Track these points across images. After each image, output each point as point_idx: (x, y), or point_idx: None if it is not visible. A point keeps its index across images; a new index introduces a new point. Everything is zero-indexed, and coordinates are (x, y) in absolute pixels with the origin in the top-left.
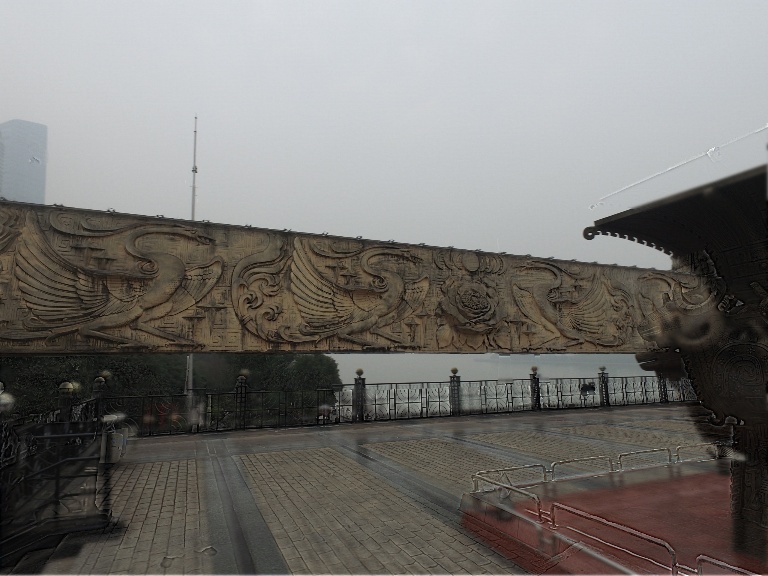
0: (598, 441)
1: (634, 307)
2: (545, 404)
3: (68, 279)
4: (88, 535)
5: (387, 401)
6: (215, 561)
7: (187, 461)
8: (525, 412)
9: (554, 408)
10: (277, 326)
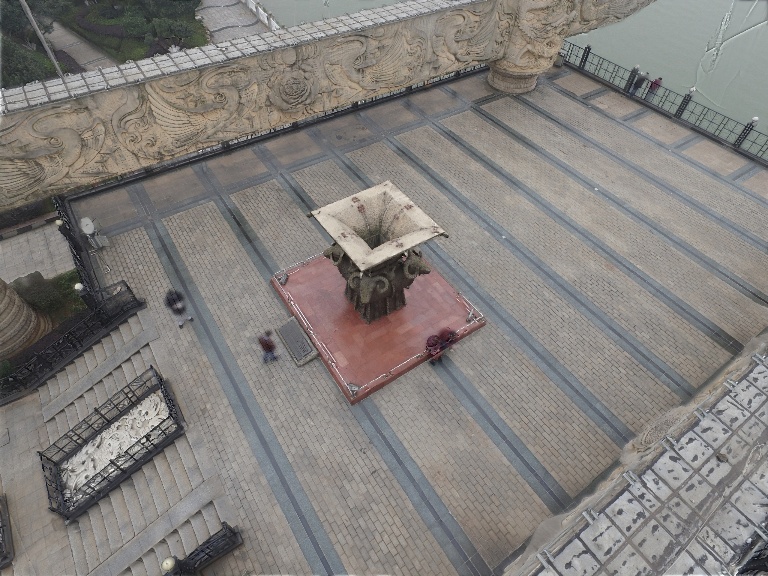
0: (361, 185)
1: (426, 49)
2: (362, 101)
3: (9, 165)
4: (145, 312)
5: None
6: (195, 324)
7: (140, 230)
8: (346, 111)
9: (369, 101)
10: (157, 148)
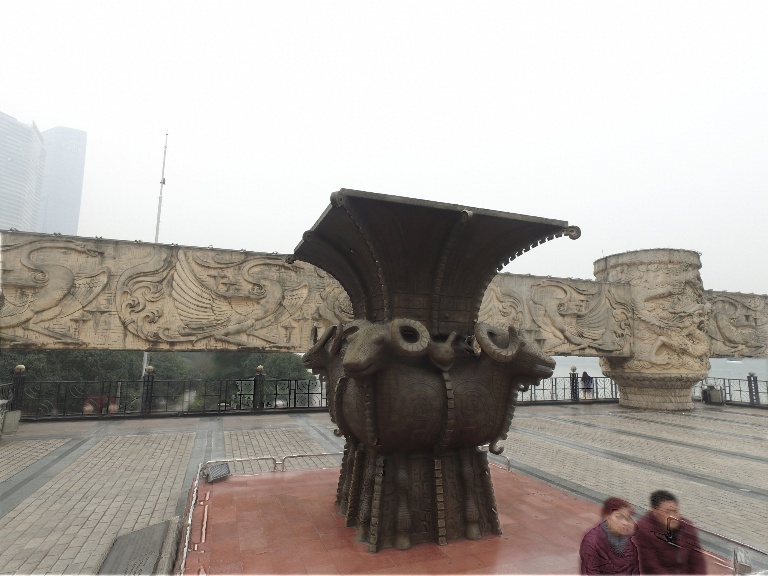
0: None
1: (523, 313)
2: None
3: None
4: None
5: (288, 391)
6: None
7: (63, 440)
8: None
9: None
10: (157, 328)
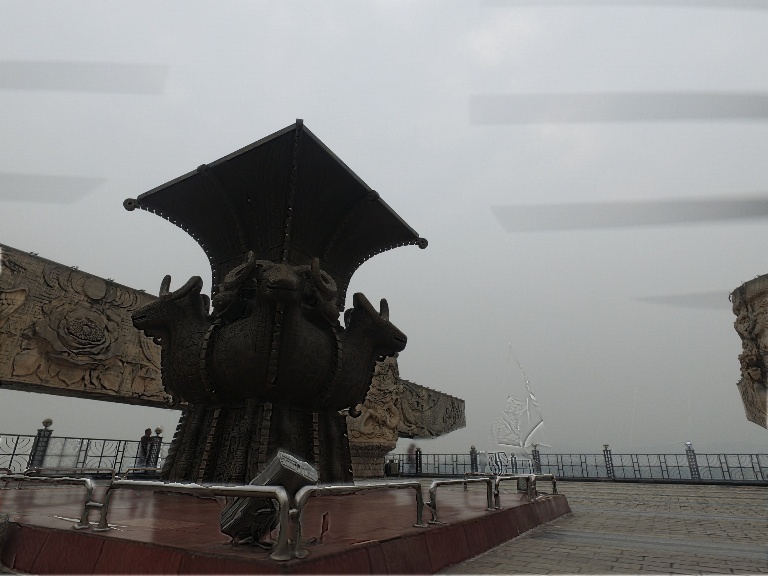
0: None
1: None
2: None
3: None
4: None
5: None
6: None
7: None
8: (134, 474)
9: None
10: None
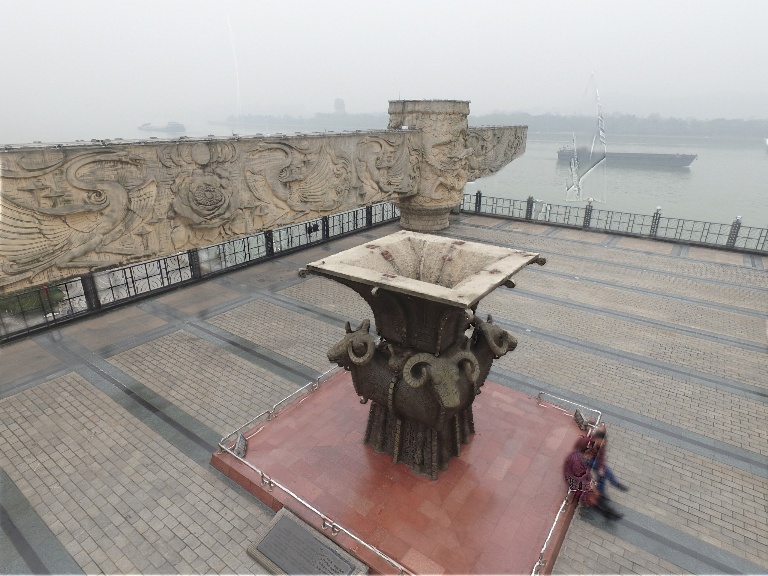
0: (312, 315)
1: (352, 172)
2: (277, 248)
3: None
4: None
5: (124, 281)
6: None
7: None
8: (260, 259)
9: (285, 249)
10: None
